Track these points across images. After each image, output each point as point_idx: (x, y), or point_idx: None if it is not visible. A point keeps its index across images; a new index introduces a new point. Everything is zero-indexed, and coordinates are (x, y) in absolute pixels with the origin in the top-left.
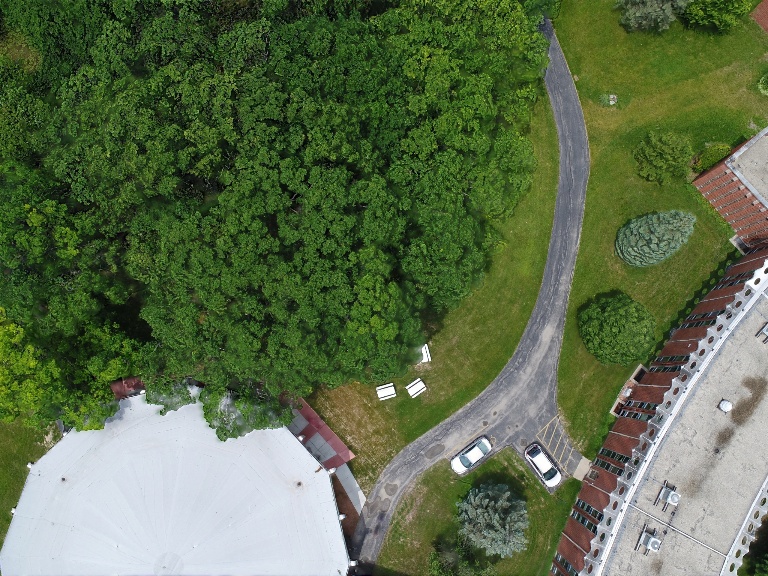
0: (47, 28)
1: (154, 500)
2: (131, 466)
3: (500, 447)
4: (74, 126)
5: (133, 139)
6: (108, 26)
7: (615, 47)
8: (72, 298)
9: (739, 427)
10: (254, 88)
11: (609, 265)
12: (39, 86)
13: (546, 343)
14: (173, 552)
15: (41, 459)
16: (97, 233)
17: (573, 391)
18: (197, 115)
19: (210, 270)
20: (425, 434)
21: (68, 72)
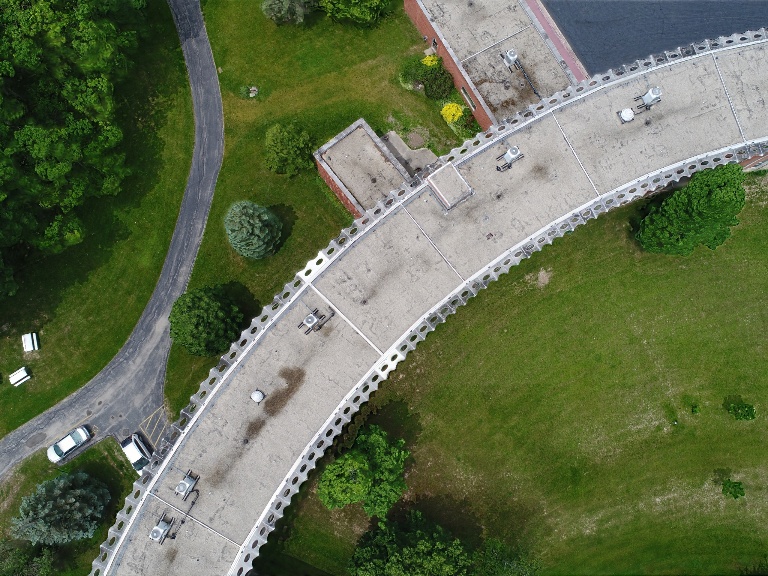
0: None
1: None
2: None
3: (101, 437)
4: None
5: None
6: None
7: (263, 40)
8: None
9: (271, 418)
10: None
11: (231, 257)
12: None
13: (159, 334)
14: None
15: None
16: None
17: (181, 382)
18: None
19: None
20: (28, 422)
21: None
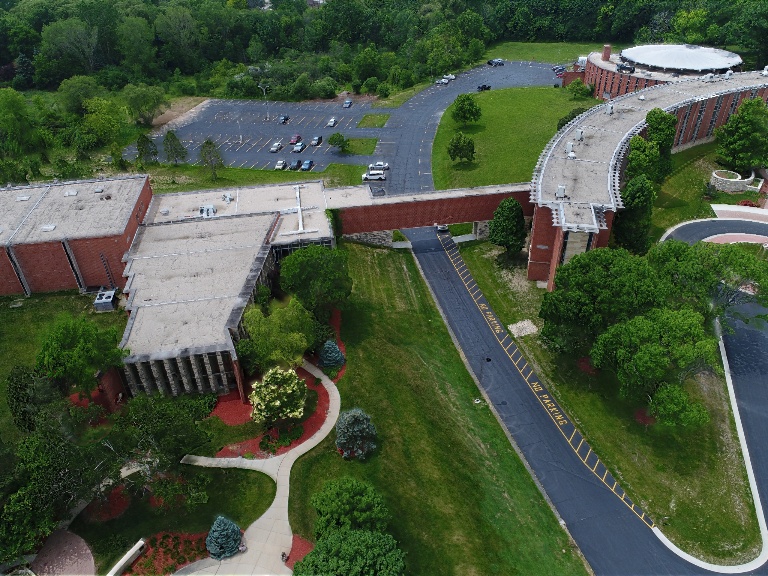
0: None
1: None
2: None
3: None
4: None
5: None
6: None
7: None
8: None
9: None
10: None
11: None
12: None
13: None
14: None
15: (666, 45)
16: None
17: None
18: None
19: None
20: None
21: None
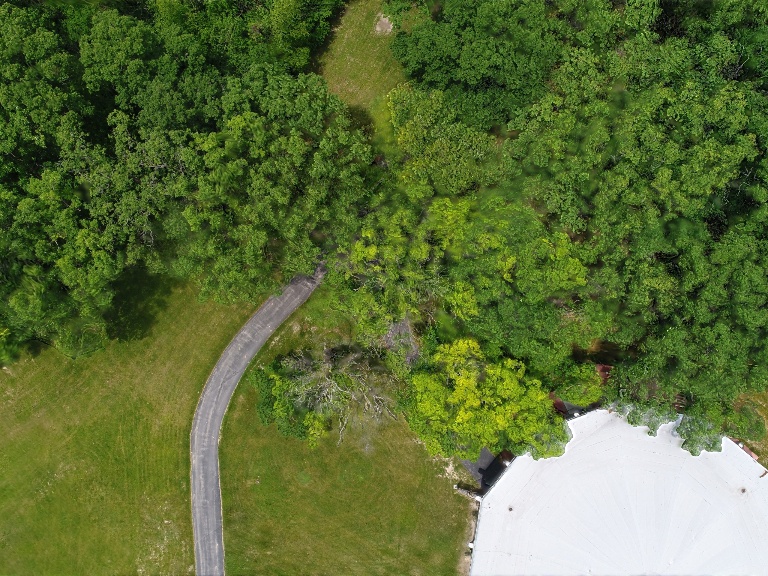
0: (496, 60)
1: (615, 521)
2: (577, 490)
3: None
4: (546, 156)
5: (663, 164)
6: (572, 53)
7: None
8: (578, 328)
9: None
10: (762, 102)
11: None
12: (481, 119)
13: None
14: (652, 571)
15: (490, 492)
16: (599, 261)
17: None
18: (712, 134)
19: (757, 288)
20: None
21: (528, 102)
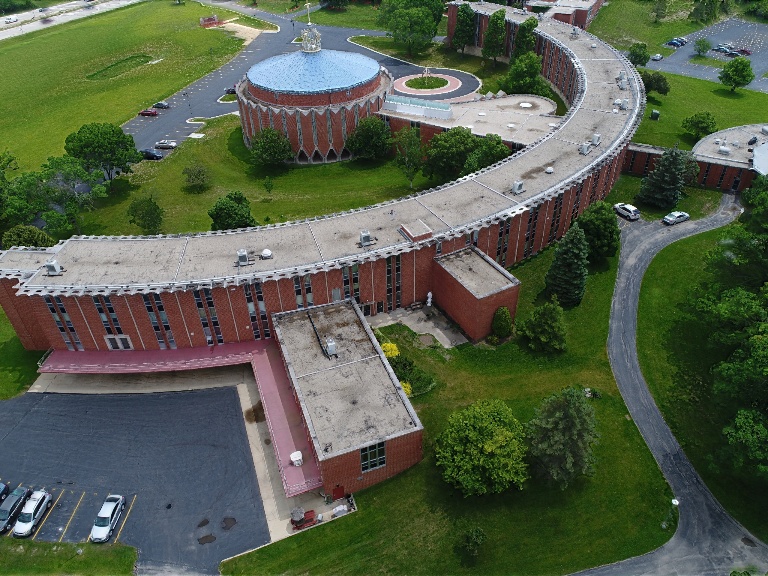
0: None
1: None
2: None
3: None
4: None
5: None
6: None
7: None
8: None
9: None
10: None
11: None
12: None
13: (632, 257)
14: None
15: None
16: None
17: None
18: None
19: None
20: None
21: None
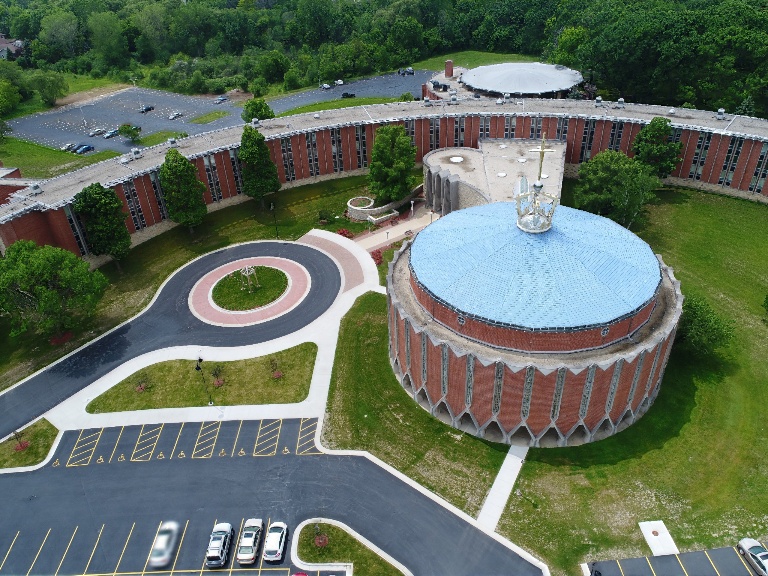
0: None
1: None
2: None
3: None
4: None
5: None
6: None
7: None
8: None
9: None
10: None
11: None
12: None
13: None
14: None
15: None
16: None
17: None
18: None
19: None
20: None
21: None
